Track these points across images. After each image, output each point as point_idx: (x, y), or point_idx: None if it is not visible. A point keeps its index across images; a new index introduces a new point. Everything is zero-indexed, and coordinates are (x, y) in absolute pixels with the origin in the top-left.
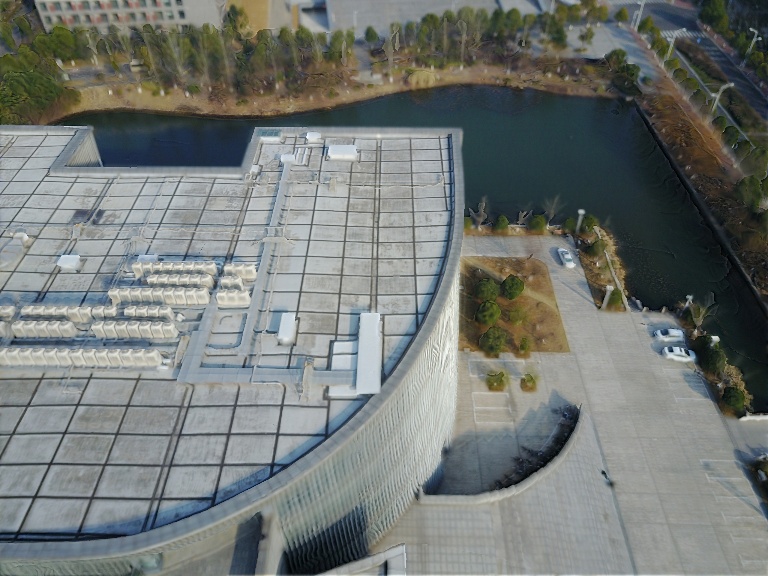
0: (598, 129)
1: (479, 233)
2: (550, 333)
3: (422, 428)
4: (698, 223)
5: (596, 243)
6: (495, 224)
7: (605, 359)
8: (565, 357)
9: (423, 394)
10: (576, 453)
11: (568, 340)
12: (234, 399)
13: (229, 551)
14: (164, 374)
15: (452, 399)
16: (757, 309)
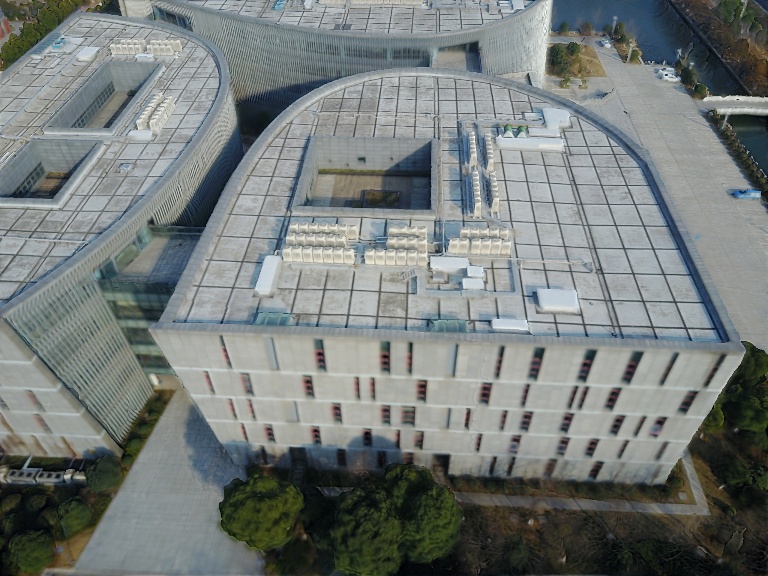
0: (628, 2)
1: (550, 35)
2: (596, 71)
3: (535, 58)
4: (693, 43)
5: (624, 34)
6: (561, 28)
7: (628, 80)
8: (604, 79)
9: (538, 34)
10: (610, 102)
11: (606, 73)
12: (459, 13)
13: (464, 60)
14: (424, 8)
15: (543, 77)
16: (723, 69)
